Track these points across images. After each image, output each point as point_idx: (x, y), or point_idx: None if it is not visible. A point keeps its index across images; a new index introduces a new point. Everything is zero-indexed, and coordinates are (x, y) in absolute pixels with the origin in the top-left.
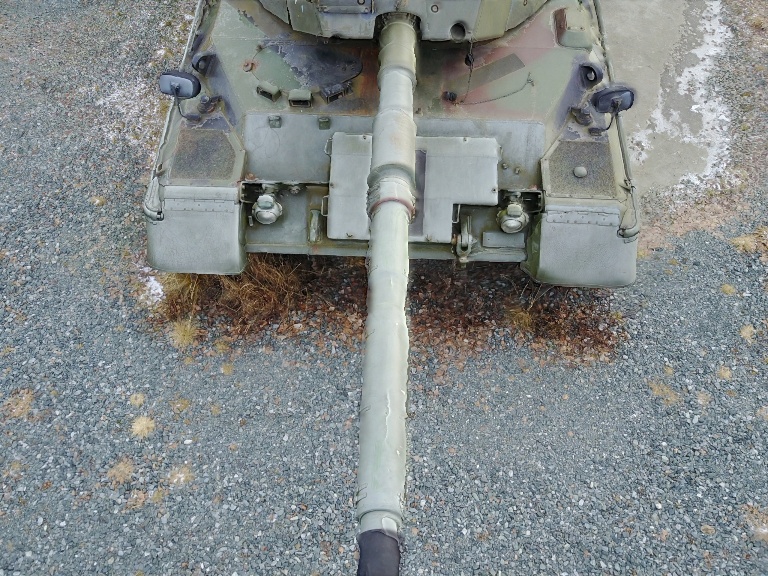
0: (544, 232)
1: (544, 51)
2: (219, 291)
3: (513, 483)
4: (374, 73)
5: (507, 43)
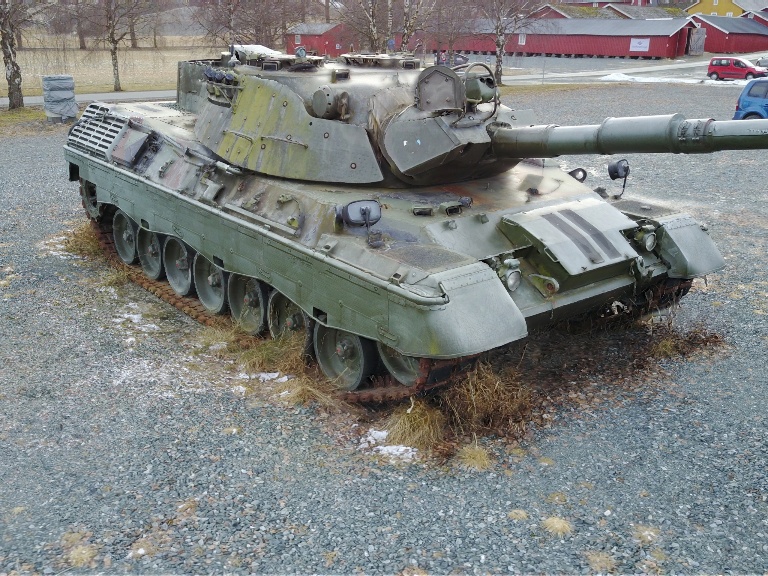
0: (673, 237)
1: (541, 170)
2: (453, 426)
3: None
4: (469, 194)
5: (516, 172)
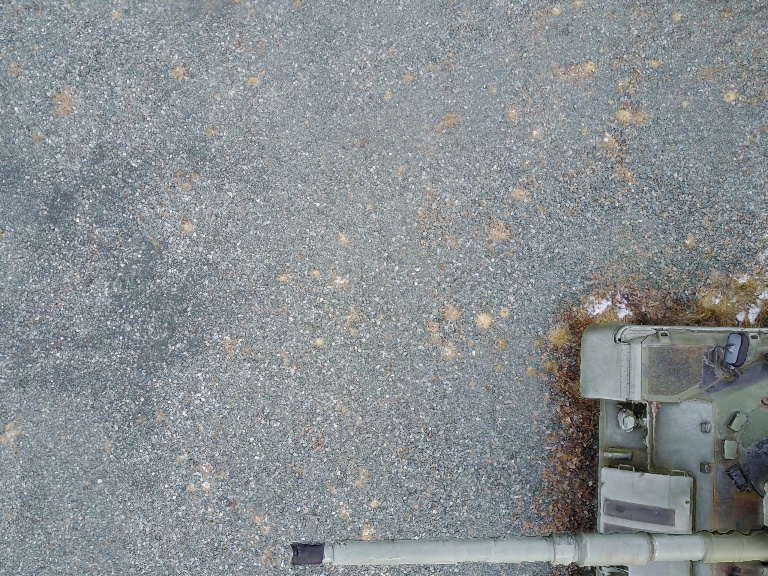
0: None
1: None
2: None
3: (450, 571)
4: None
5: None
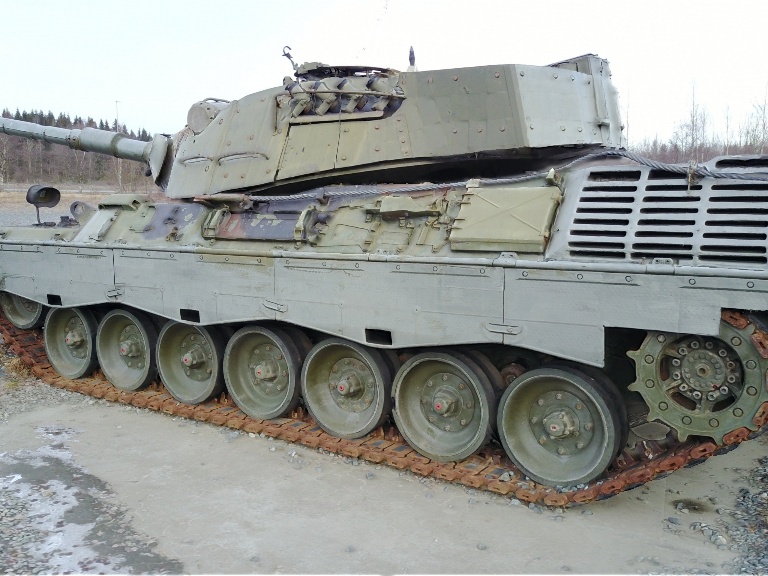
0: None
1: None
2: None
3: None
4: None
5: None
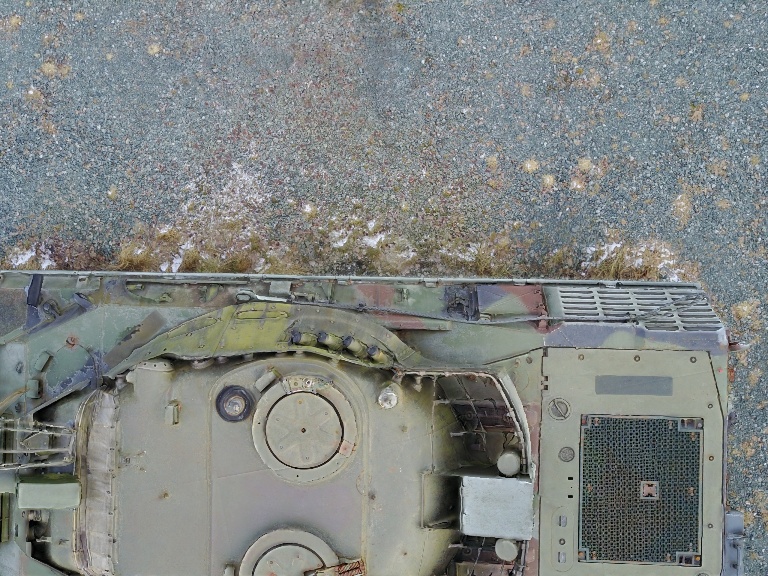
0: None
1: None
2: None
3: None
4: None
5: None
